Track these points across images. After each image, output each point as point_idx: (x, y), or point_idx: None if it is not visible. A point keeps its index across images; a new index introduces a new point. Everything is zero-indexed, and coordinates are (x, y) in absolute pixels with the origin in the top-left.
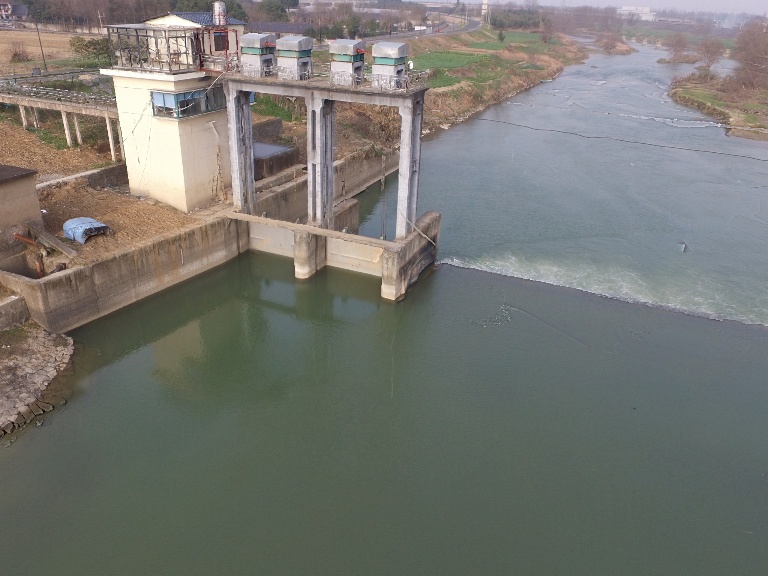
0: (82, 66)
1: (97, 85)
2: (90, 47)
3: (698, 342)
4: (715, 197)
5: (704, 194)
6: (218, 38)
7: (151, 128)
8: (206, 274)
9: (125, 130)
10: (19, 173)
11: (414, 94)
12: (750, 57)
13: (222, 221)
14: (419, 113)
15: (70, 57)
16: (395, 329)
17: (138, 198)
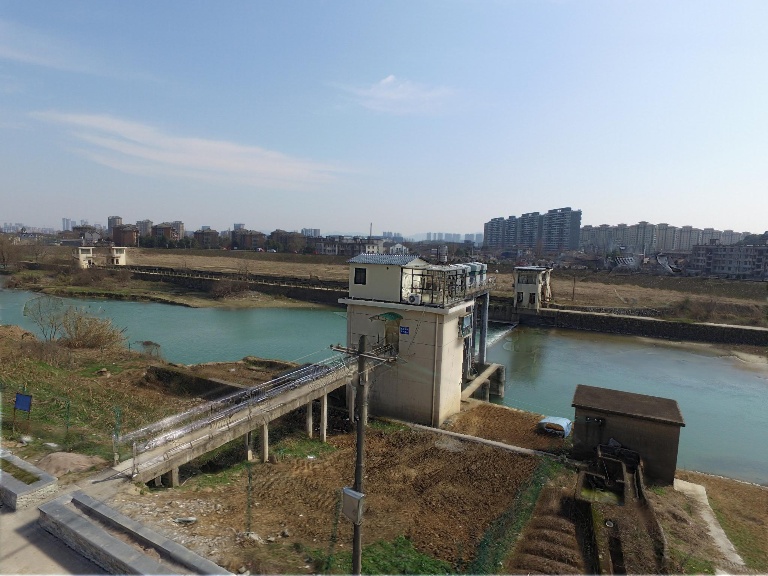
0: None
1: None
2: None
3: None
4: None
5: None
6: None
7: (454, 350)
8: None
9: (443, 362)
10: (593, 387)
11: None
12: (54, 260)
13: None
14: None
15: None
16: None
17: (451, 422)
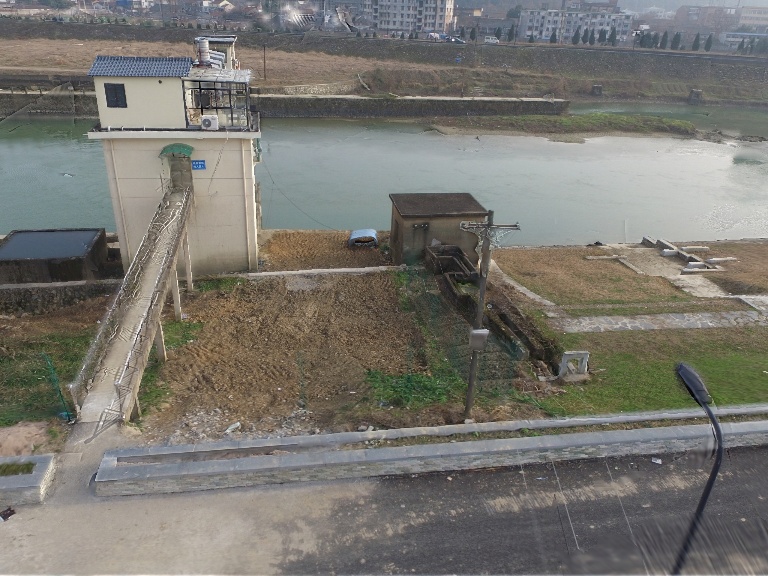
0: None
1: None
2: None
3: None
4: (2, 147)
5: None
6: None
7: None
8: None
9: None
10: (404, 194)
11: None
12: None
13: None
14: None
15: None
16: None
17: (266, 261)
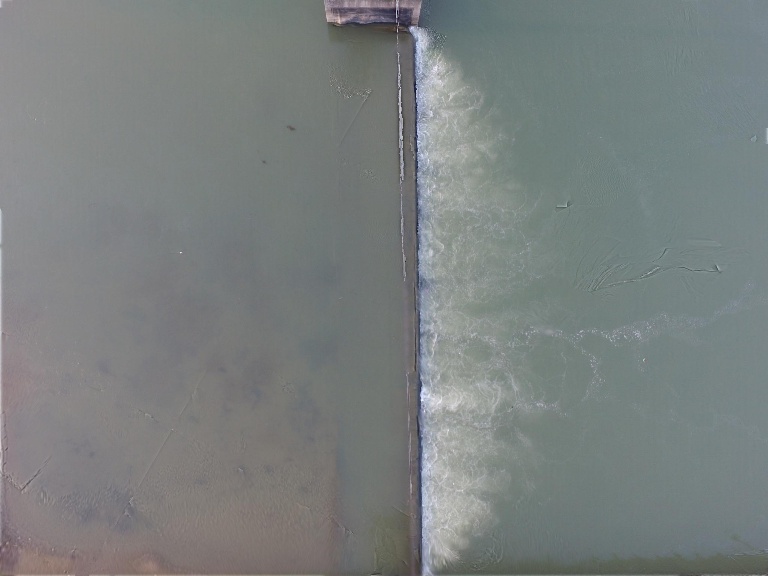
0: None
1: None
2: None
3: (377, 210)
4: (659, 222)
5: (667, 212)
6: None
7: None
8: None
9: None
10: None
11: None
12: None
13: None
14: None
15: None
16: (330, 37)
17: None
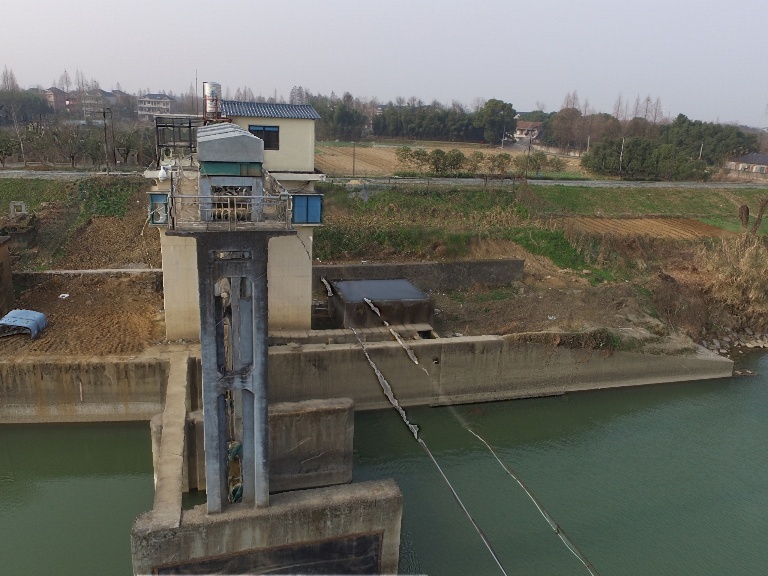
0: (398, 174)
1: (358, 191)
2: (415, 157)
3: None
4: None
5: None
6: (260, 133)
7: None
8: (123, 425)
9: None
10: None
11: (201, 235)
12: None
13: (158, 365)
14: (247, 277)
15: (392, 165)
16: None
17: (161, 309)
